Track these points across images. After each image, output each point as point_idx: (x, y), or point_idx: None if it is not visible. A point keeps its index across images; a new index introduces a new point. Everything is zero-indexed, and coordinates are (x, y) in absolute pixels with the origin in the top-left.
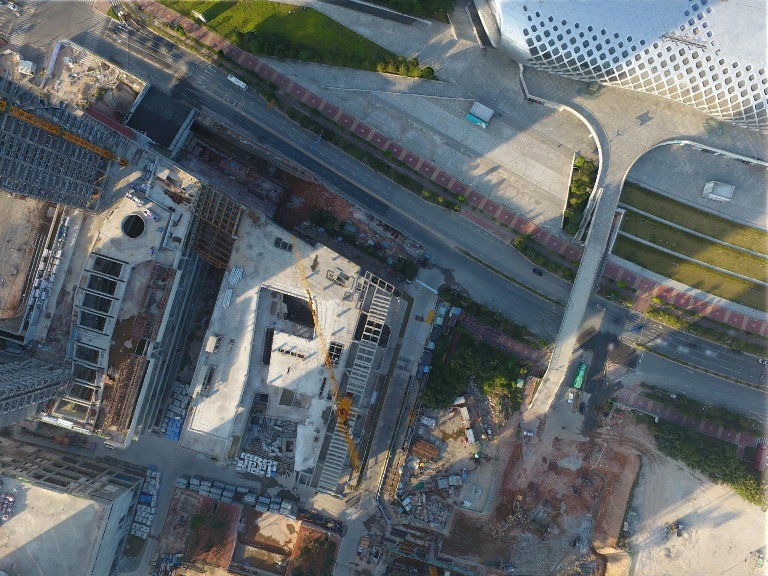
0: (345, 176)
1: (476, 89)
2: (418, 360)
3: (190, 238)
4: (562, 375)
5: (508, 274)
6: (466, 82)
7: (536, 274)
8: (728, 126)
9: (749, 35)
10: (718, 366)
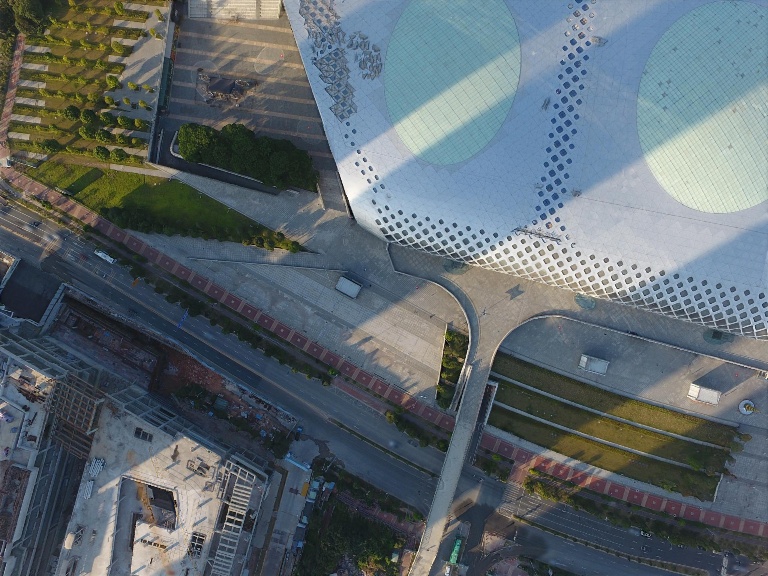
0: (216, 348)
1: (345, 259)
2: (293, 533)
3: (50, 430)
4: (433, 555)
5: (383, 445)
6: (335, 252)
7: (411, 445)
8: (601, 299)
9: (604, 230)
10: (599, 538)
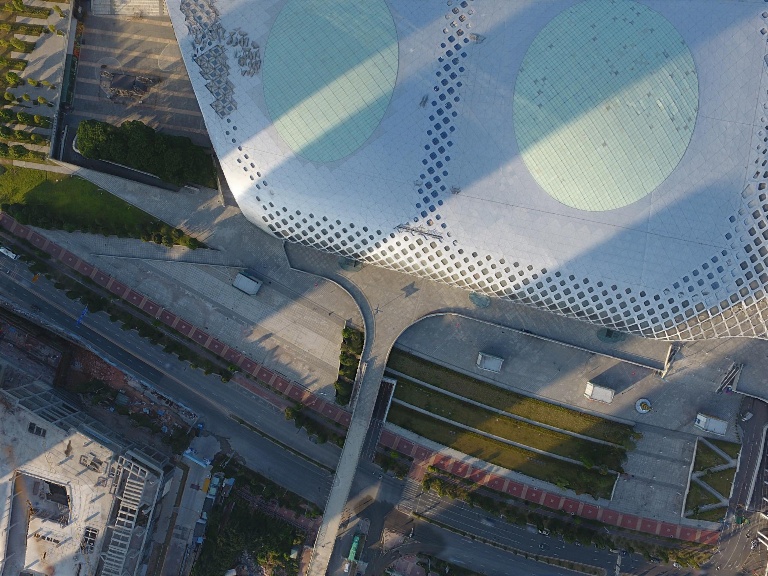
0: (119, 344)
1: (245, 256)
2: None
3: None
4: (329, 551)
5: (284, 442)
6: (235, 249)
7: (312, 442)
8: None
9: (484, 227)
10: (497, 536)
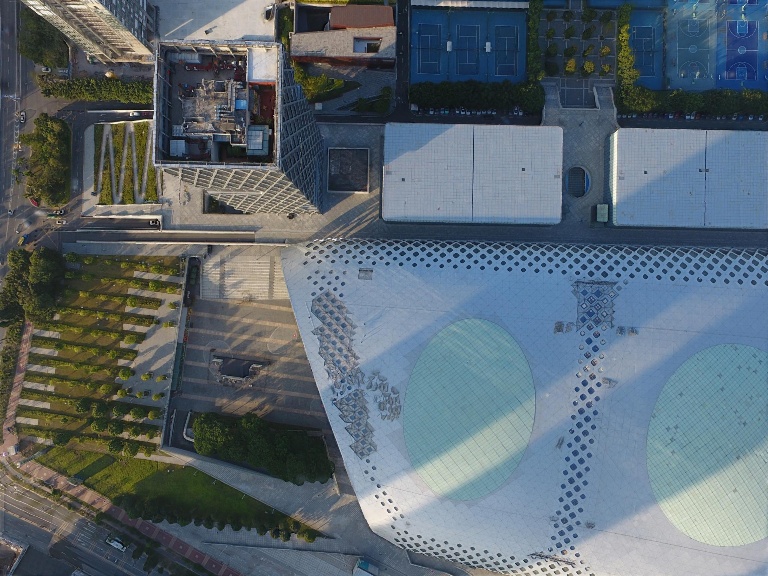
0: None
1: (361, 543)
2: None
3: None
4: None
5: None
6: (350, 536)
7: None
8: None
9: (616, 557)
10: None
